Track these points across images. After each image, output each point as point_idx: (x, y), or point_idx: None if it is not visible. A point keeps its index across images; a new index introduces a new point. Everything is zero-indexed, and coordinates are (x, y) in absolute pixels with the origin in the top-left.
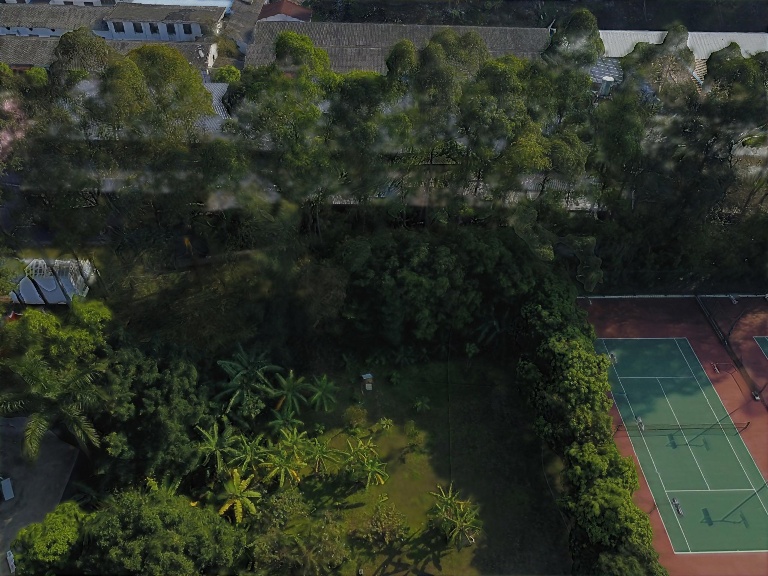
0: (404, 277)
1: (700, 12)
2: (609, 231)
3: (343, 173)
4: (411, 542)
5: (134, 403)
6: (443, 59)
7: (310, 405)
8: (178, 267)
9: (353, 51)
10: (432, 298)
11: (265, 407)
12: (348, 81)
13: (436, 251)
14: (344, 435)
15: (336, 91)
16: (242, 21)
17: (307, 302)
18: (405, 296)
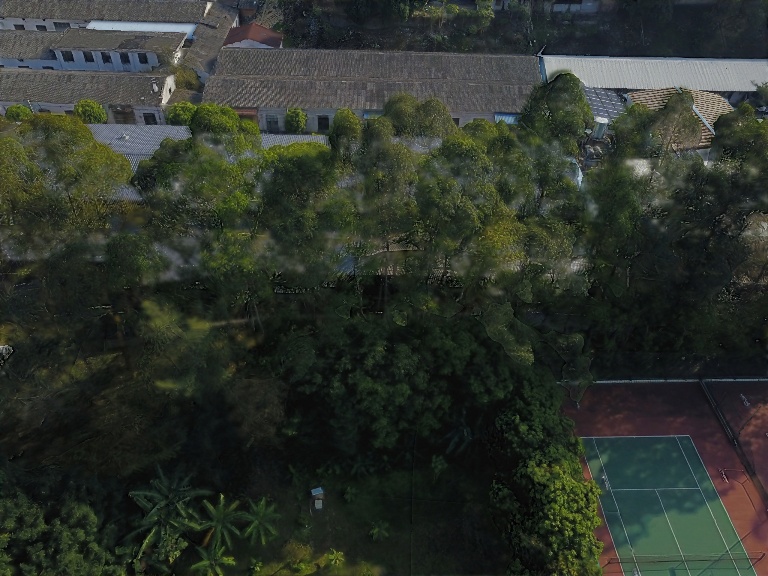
0: (356, 384)
1: (702, 36)
2: (600, 317)
3: (275, 273)
4: None
5: (10, 569)
6: (393, 141)
7: (244, 537)
8: (108, 348)
9: (322, 84)
10: (391, 406)
11: (187, 546)
12: (282, 161)
13: (395, 351)
14: (285, 572)
15: (269, 172)
16: (205, 48)
17: (240, 416)
18: (358, 406)
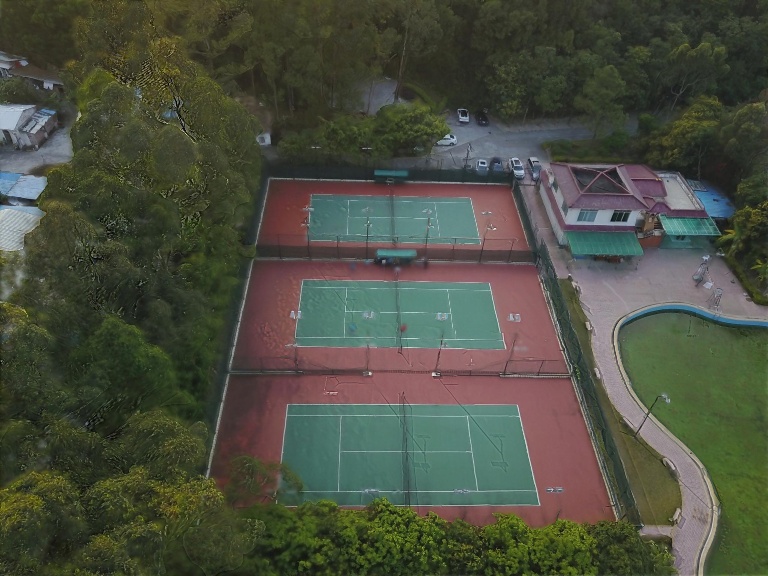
0: None
1: None
2: None
3: None
4: None
5: None
6: None
7: None
8: None
9: None
10: None
11: None
12: None
13: None
14: None
15: None
16: None
17: None
18: None
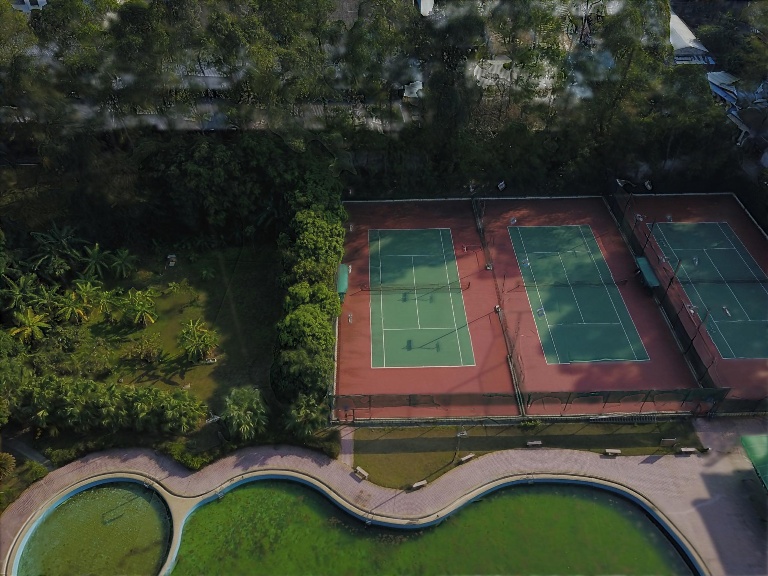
0: (187, 168)
1: None
2: (375, 137)
3: (117, 78)
4: (167, 362)
5: None
6: None
7: (112, 271)
8: (40, 182)
9: None
10: (213, 187)
11: (70, 269)
12: (121, 6)
13: (215, 148)
14: None
15: (114, 15)
16: None
17: (107, 188)
18: (189, 184)
